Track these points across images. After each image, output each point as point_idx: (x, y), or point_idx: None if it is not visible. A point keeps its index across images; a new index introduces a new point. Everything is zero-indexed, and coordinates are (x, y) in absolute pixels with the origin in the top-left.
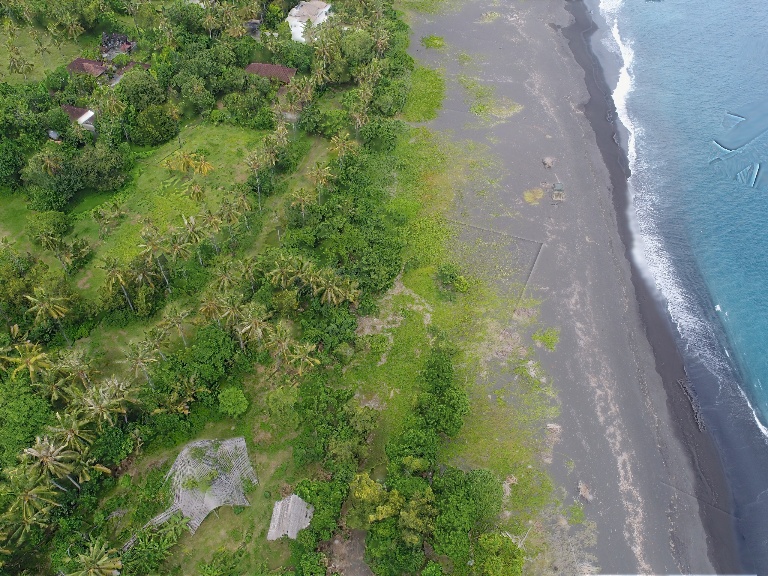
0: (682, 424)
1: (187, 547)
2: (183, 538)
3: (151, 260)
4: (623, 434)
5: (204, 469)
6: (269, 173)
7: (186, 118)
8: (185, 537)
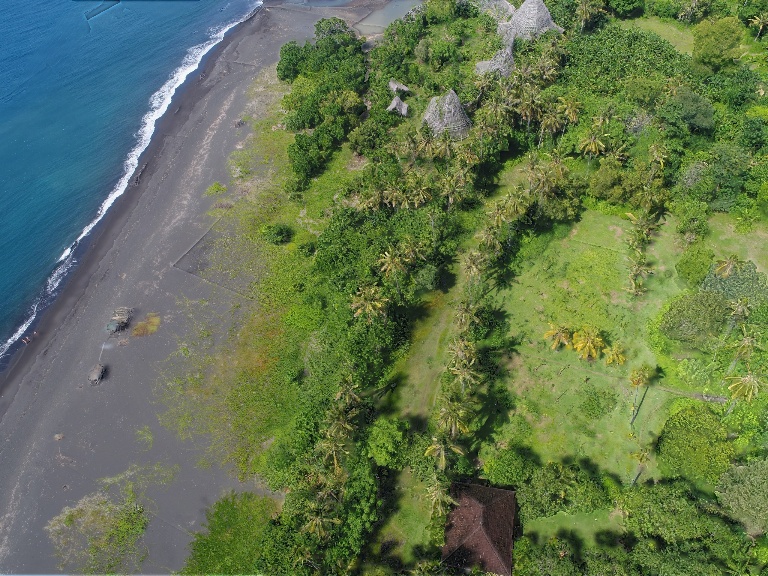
0: None
1: None
2: None
3: None
4: None
5: None
6: (476, 364)
7: None
8: None
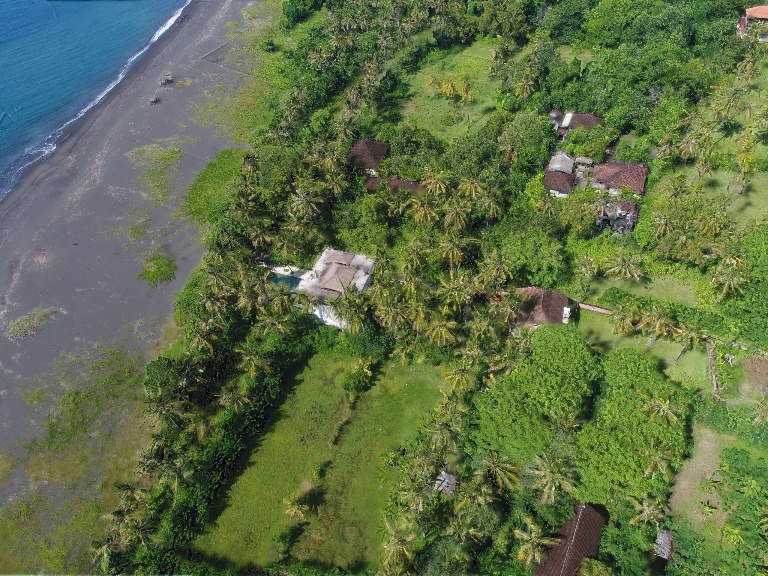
0: None
1: None
2: None
3: None
4: None
5: None
6: None
7: None
8: None
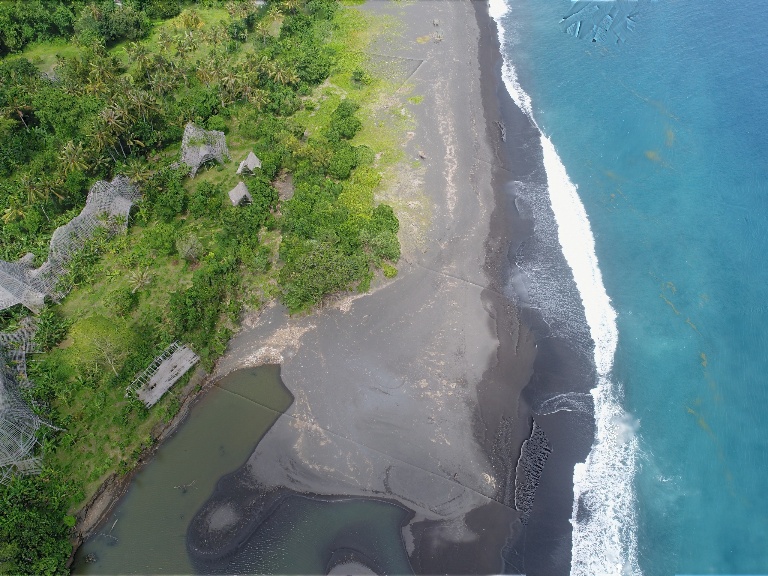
0: (492, 138)
1: (190, 184)
2: (187, 181)
3: (165, 61)
4: (454, 139)
5: (199, 135)
6: None
7: (185, 5)
8: (189, 180)
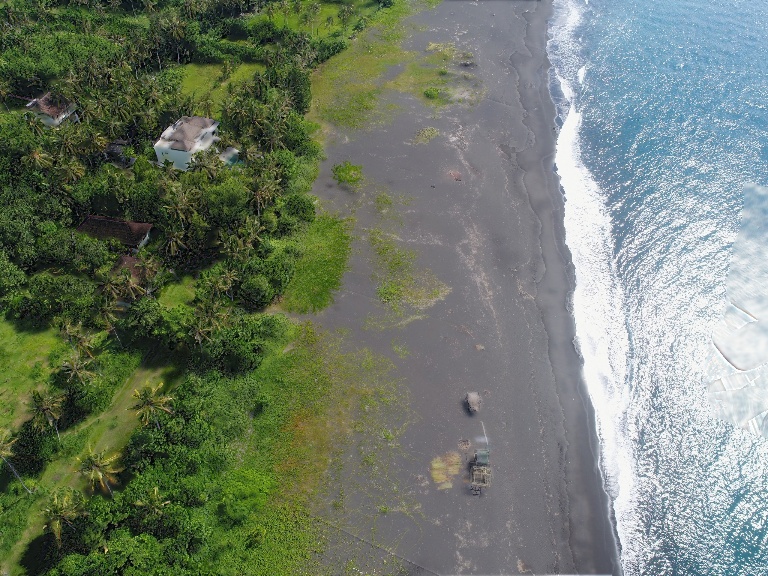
0: None
1: None
2: None
3: None
4: None
5: None
6: (65, 414)
7: None
8: None
